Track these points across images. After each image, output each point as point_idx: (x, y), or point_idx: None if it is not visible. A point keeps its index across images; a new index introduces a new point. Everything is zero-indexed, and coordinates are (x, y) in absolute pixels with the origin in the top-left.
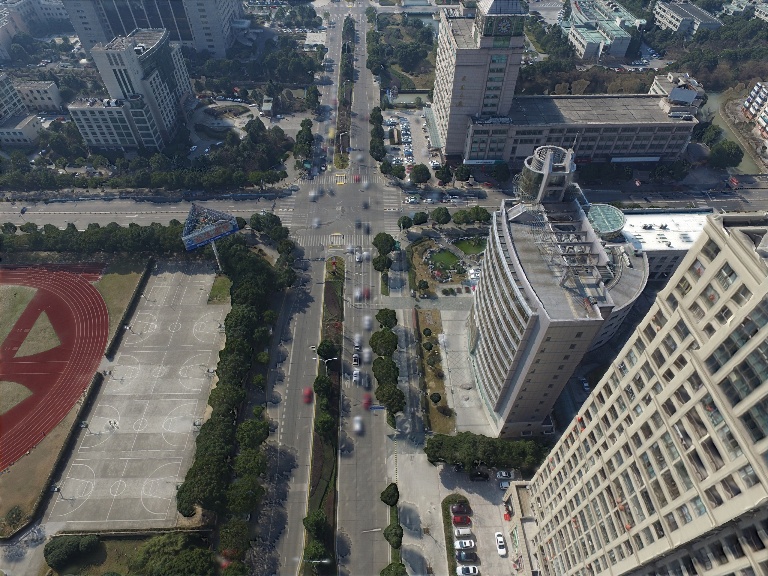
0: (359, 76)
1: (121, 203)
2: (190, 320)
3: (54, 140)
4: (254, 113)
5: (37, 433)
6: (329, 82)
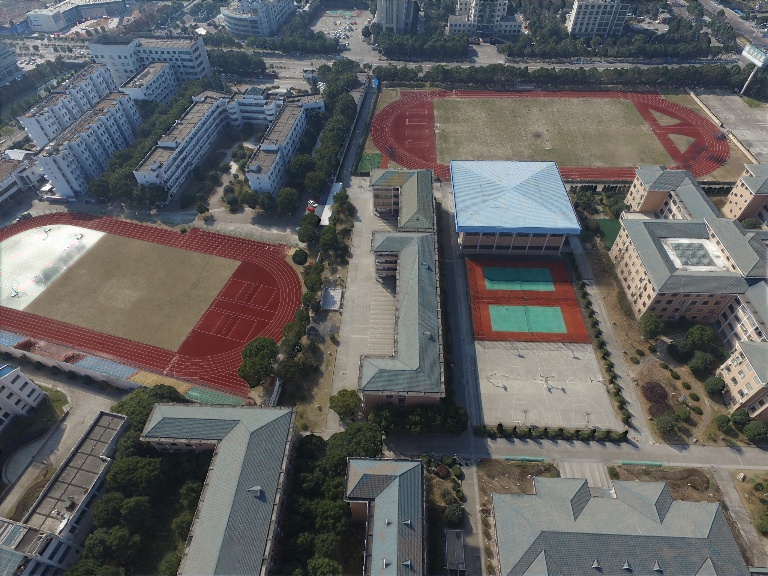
0: (701, 2)
1: (623, 65)
2: (750, 114)
3: (554, 28)
4: (651, 21)
5: (722, 152)
6: (682, 6)
